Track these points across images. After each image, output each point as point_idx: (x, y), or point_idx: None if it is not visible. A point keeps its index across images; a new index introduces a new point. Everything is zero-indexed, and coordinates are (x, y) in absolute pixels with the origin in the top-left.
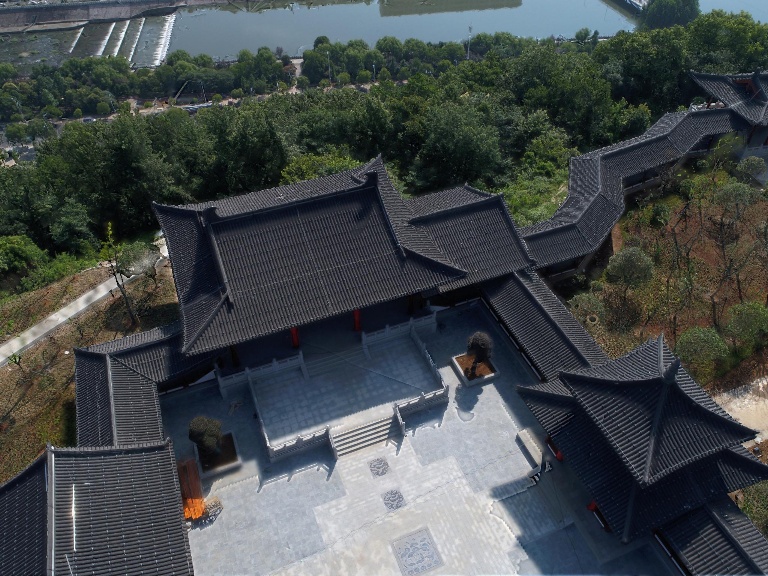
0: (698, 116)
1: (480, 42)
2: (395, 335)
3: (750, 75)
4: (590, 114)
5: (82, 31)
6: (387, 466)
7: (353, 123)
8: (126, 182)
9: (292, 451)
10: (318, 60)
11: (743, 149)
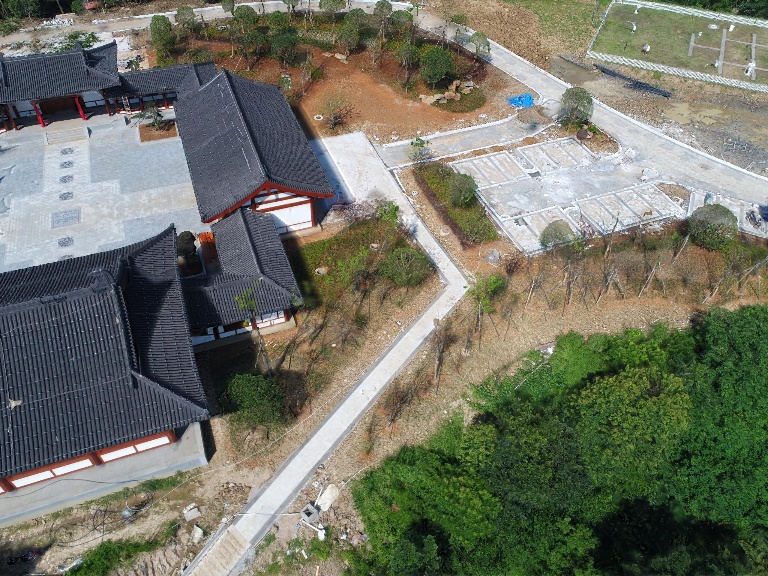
0: None
1: None
2: None
3: None
4: None
5: None
6: None
7: None
8: None
9: None
10: None
11: None
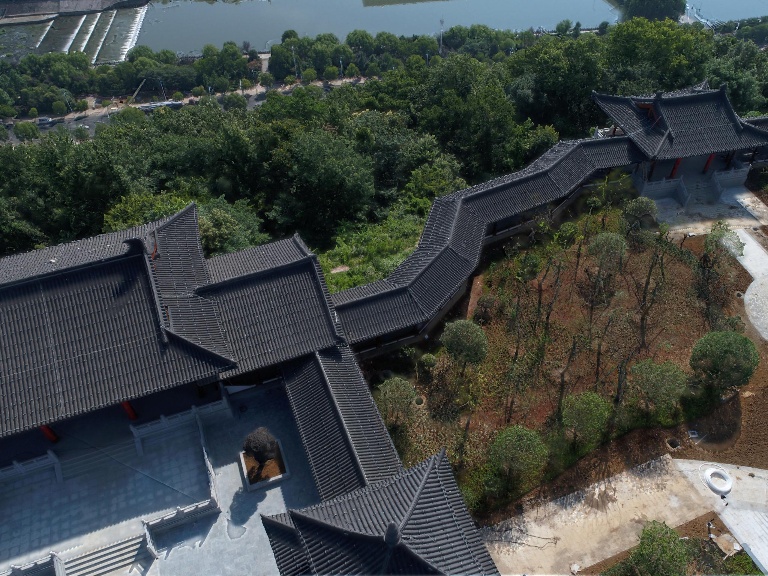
0: (591, 146)
1: (455, 35)
2: (177, 424)
3: (651, 99)
4: (488, 138)
5: (51, 24)
6: None
7: (213, 151)
8: None
9: None
10: (283, 56)
11: (642, 184)
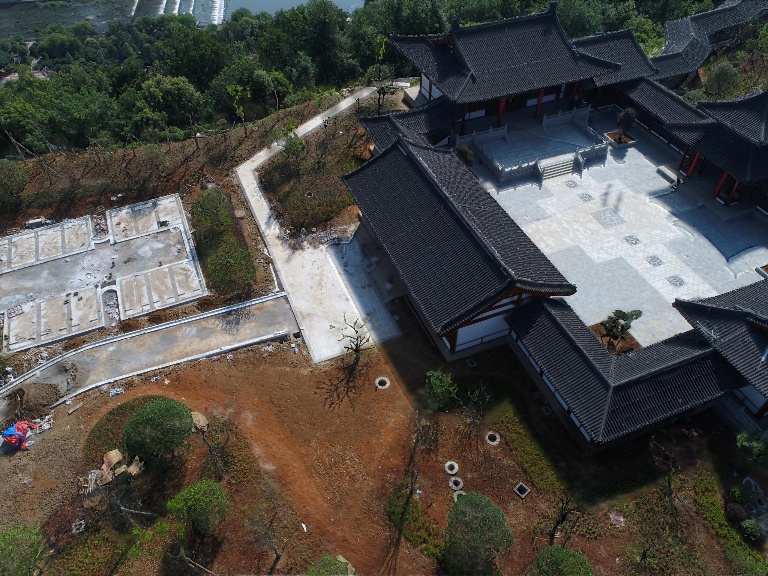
0: None
1: None
2: (563, 121)
3: None
4: (666, 6)
5: None
6: (576, 183)
7: (488, 9)
8: (325, 50)
9: (514, 175)
10: (371, 16)
11: None
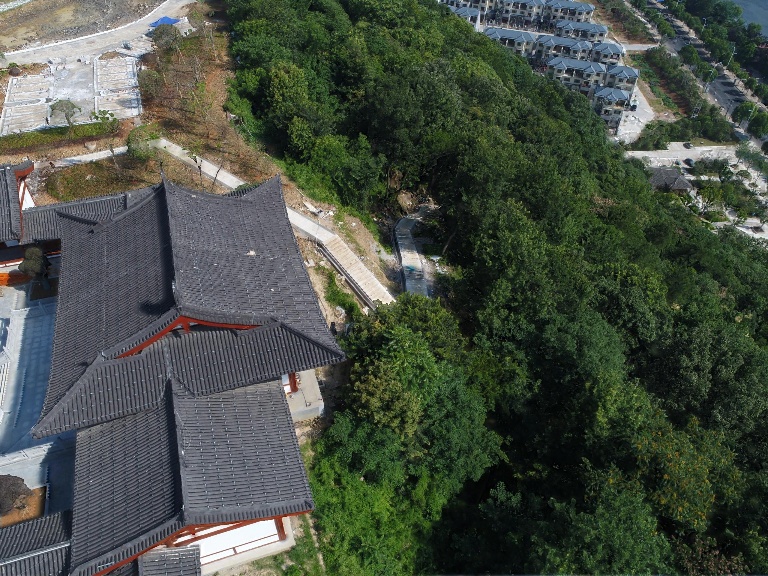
0: None
1: None
2: None
3: None
4: None
5: None
6: None
7: None
8: None
9: None
10: None
11: None
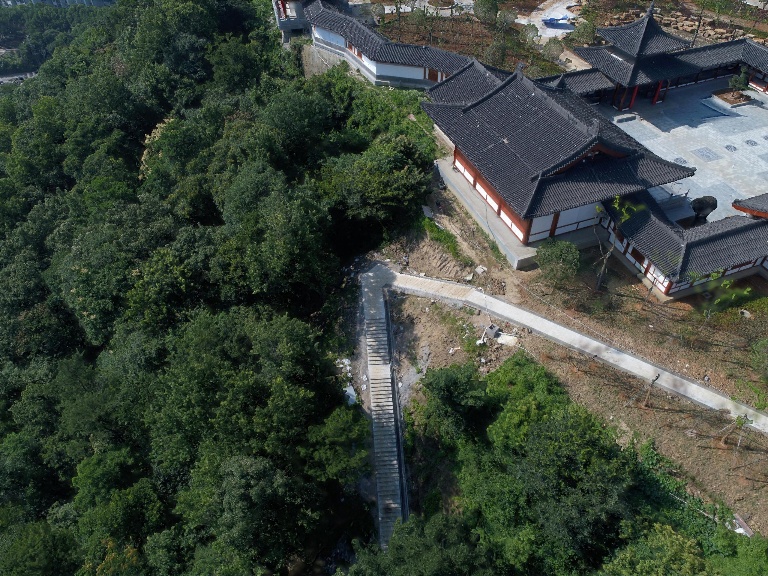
0: None
1: None
2: None
3: None
4: (256, 64)
5: None
6: None
7: None
8: (334, 372)
9: None
10: None
11: None
